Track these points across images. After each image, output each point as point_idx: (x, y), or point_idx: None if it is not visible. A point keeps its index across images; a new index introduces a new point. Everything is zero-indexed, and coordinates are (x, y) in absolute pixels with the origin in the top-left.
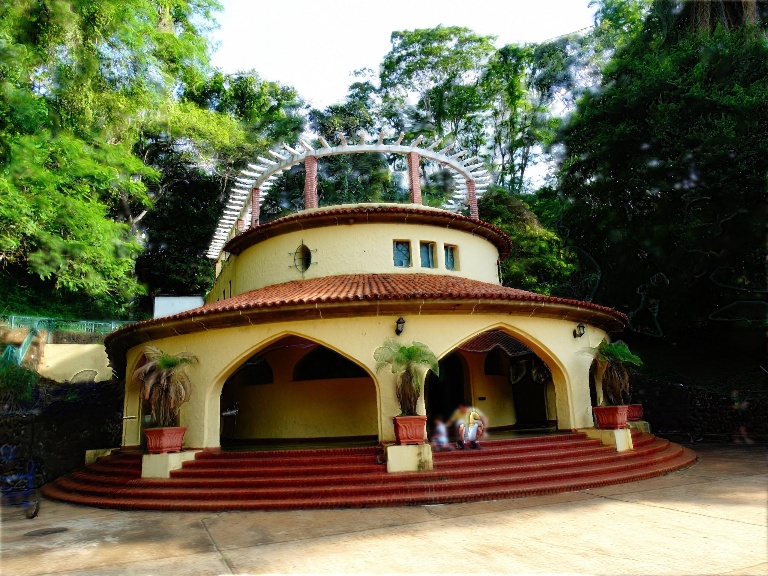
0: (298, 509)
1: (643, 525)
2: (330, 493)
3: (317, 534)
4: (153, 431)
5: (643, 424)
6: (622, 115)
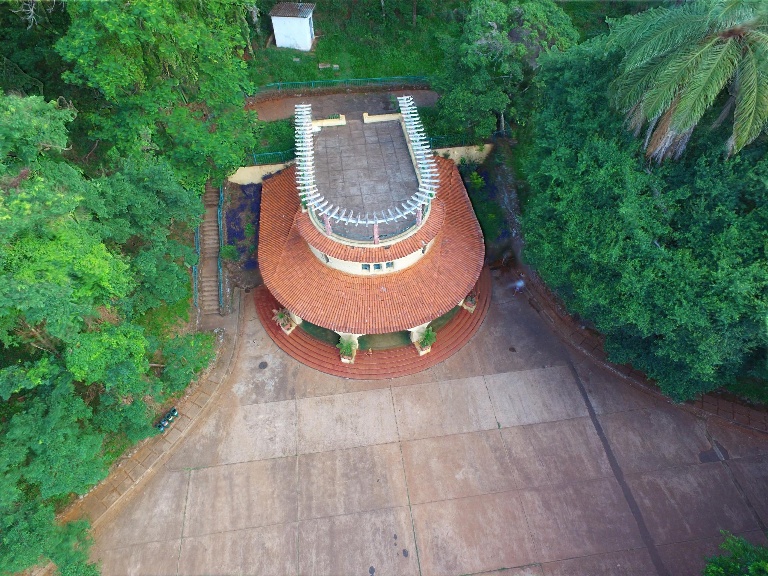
0: (317, 370)
1: (376, 416)
2: (325, 367)
3: (315, 395)
4: (282, 326)
5: (471, 310)
6: (548, 153)
